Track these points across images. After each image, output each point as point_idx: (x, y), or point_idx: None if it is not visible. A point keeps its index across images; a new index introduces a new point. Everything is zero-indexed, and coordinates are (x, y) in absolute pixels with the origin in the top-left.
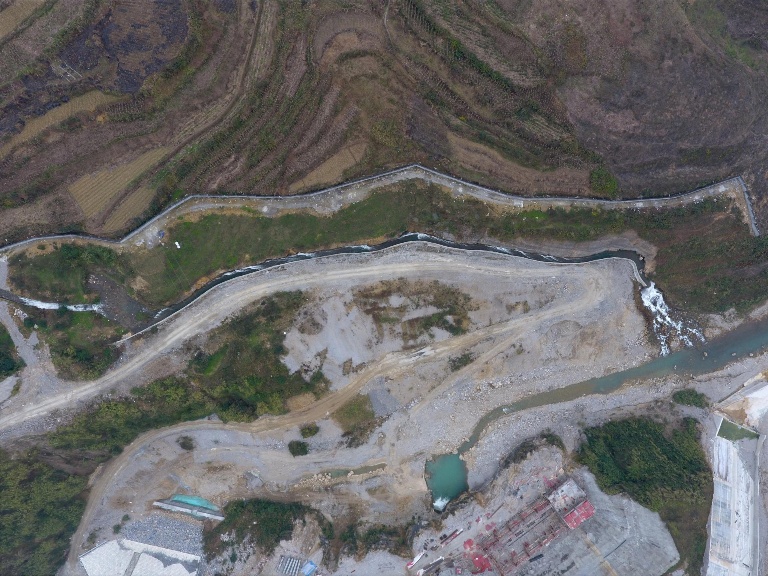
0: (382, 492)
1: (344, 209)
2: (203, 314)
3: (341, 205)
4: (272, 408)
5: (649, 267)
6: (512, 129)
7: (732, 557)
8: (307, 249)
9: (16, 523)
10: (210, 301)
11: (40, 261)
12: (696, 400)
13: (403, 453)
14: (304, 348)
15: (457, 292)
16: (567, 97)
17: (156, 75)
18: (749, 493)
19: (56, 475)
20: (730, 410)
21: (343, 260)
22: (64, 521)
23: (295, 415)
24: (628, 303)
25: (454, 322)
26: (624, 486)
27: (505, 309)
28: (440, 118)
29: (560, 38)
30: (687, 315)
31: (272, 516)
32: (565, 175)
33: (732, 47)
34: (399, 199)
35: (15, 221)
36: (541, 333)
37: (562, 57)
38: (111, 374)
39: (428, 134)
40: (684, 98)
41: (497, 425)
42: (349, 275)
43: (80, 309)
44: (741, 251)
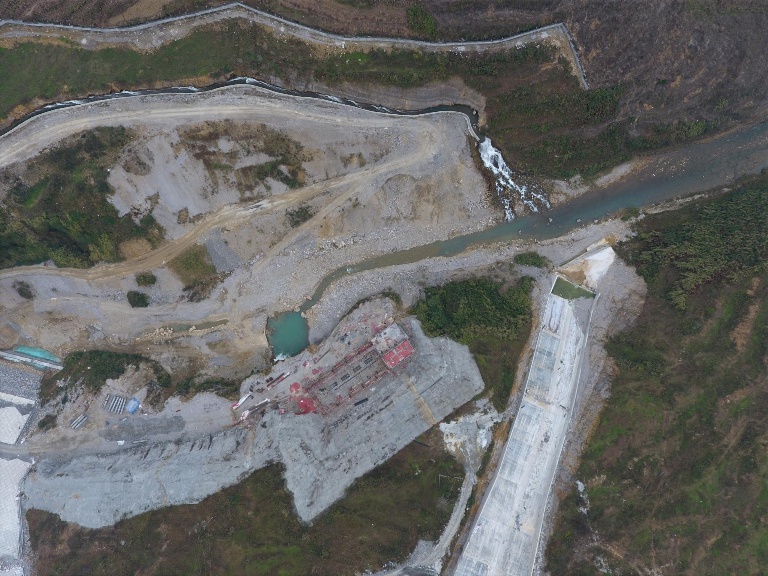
0: (222, 346)
1: (166, 45)
2: (21, 144)
3: (162, 41)
4: (103, 251)
5: (481, 120)
6: None
7: (549, 399)
8: (130, 86)
9: None
10: (29, 131)
11: None
12: (535, 260)
13: (244, 309)
14: (132, 189)
15: (287, 139)
16: None
17: None
18: (578, 345)
19: None
20: (569, 271)
21: (168, 99)
22: None
23: (131, 263)
24: (464, 159)
25: (289, 173)
26: (445, 328)
27: (340, 161)
28: None
29: None
30: (531, 180)
31: (105, 361)
32: (383, 13)
33: None
34: (222, 38)
35: None
36: (376, 186)
37: None
38: None
39: None
40: None
41: (339, 284)
42: (174, 114)
43: None
44: (574, 107)
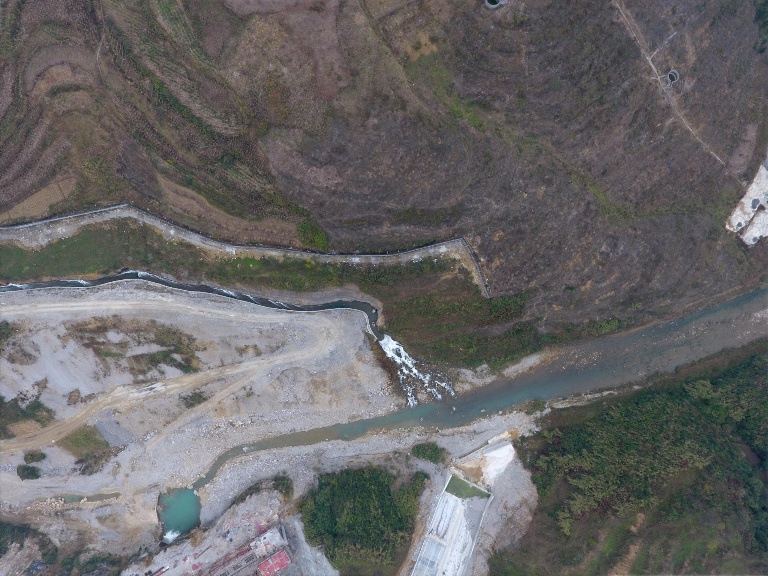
0: (112, 521)
1: (52, 244)
2: None
3: (49, 239)
4: None
5: (380, 320)
6: (215, 176)
7: None
8: (15, 281)
9: None
10: None
11: None
12: (432, 455)
13: (137, 484)
14: (18, 377)
15: (179, 332)
16: (269, 148)
17: None
18: (464, 553)
19: None
20: (467, 467)
21: (55, 294)
22: None
23: (21, 440)
24: (362, 354)
25: (183, 360)
26: (324, 539)
27: (235, 351)
28: (149, 159)
29: (262, 88)
30: (436, 368)
31: None
32: (273, 226)
33: (458, 106)
34: (112, 237)
35: None
36: (271, 378)
37: (263, 108)
38: None
39: (138, 174)
40: (388, 158)
41: (233, 464)
42: (60, 309)
43: None
44: (477, 311)
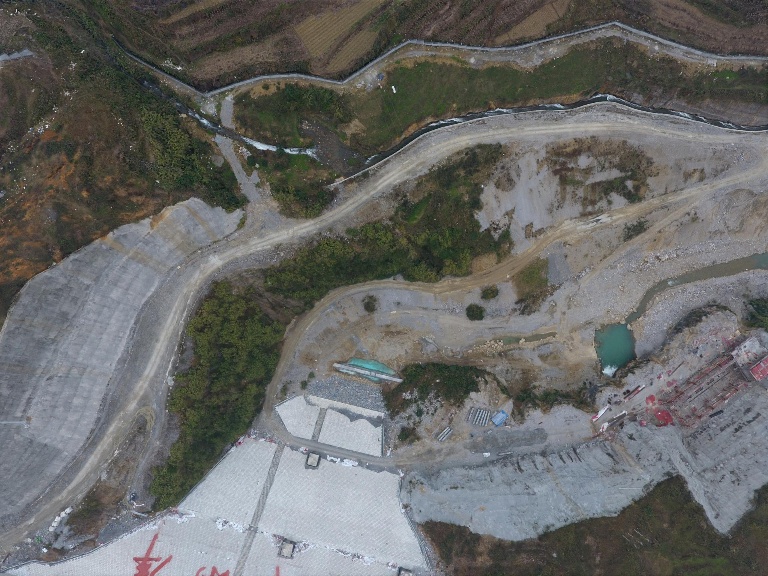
0: (553, 358)
1: (545, 64)
2: (411, 161)
3: (542, 60)
4: (461, 266)
5: None
6: None
7: None
8: (507, 104)
9: (232, 359)
10: (418, 149)
11: (262, 102)
12: None
13: (573, 321)
14: (496, 205)
15: (642, 155)
16: None
17: None
18: None
19: (264, 318)
20: None
21: (539, 117)
22: (265, 367)
23: (476, 277)
24: None
25: (633, 188)
26: None
27: (682, 177)
28: None
29: None
30: None
31: (455, 374)
32: (761, 32)
33: None
34: (596, 57)
35: (244, 59)
36: (716, 201)
37: None
38: (328, 214)
39: None
40: None
41: (664, 296)
42: (544, 132)
43: (295, 153)
44: None
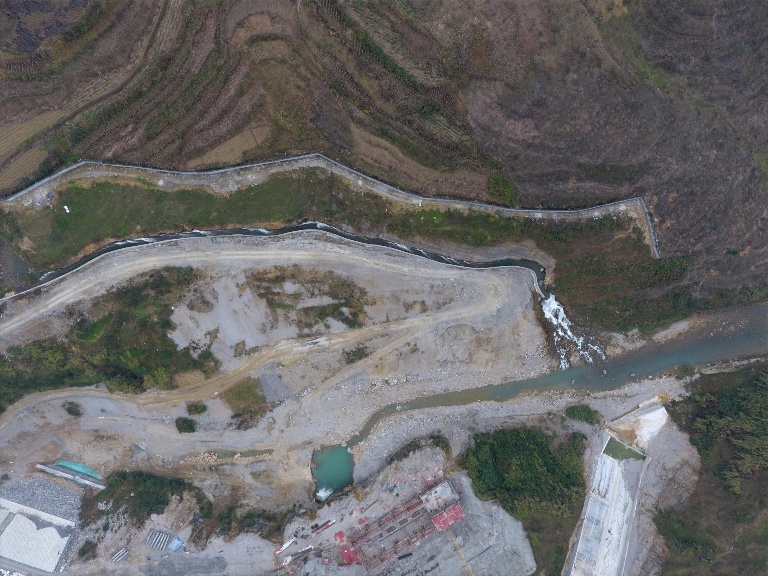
0: (266, 477)
1: (242, 190)
2: (89, 281)
3: (239, 186)
4: (158, 382)
5: (548, 279)
6: (413, 127)
7: (596, 574)
8: (202, 227)
9: None
10: (97, 268)
11: None
12: (587, 416)
13: (291, 440)
14: (193, 325)
15: (353, 285)
16: (469, 100)
17: (55, 37)
18: (626, 513)
19: None
20: (621, 429)
21: (238, 241)
22: None
23: (183, 392)
24: (526, 313)
25: (350, 315)
26: (497, 493)
27: (402, 307)
28: (344, 109)
29: (467, 40)
30: (589, 331)
31: (150, 489)
32: (464, 178)
33: (644, 67)
34: (299, 186)
35: None
36: (436, 334)
37: (467, 60)
38: None
39: (332, 124)
40: (586, 112)
41: (388, 422)
42: (243, 257)
43: None
44: (642, 272)
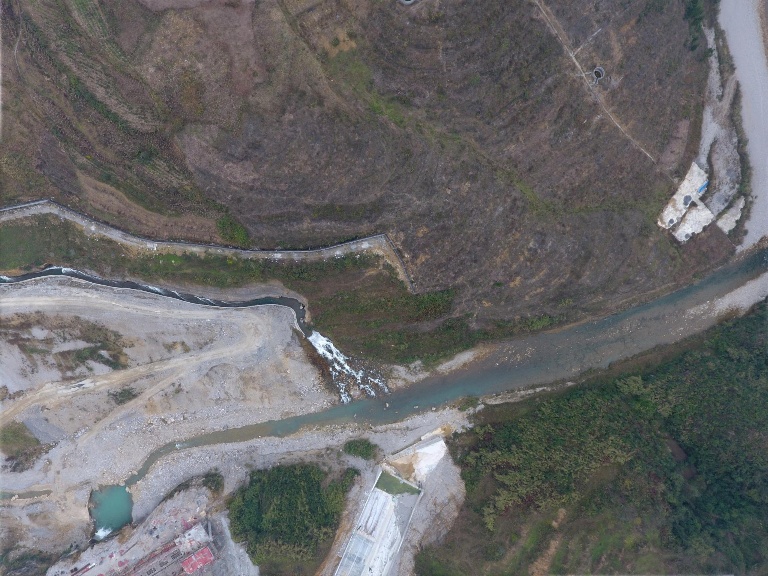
0: (43, 518)
1: None
2: None
3: None
4: None
5: (307, 317)
6: (133, 172)
7: None
8: None
9: None
10: None
11: None
12: (363, 451)
13: (68, 481)
14: None
15: (104, 328)
16: (186, 144)
17: None
18: (392, 549)
19: None
20: (398, 463)
21: None
22: None
23: None
24: (291, 350)
25: (110, 357)
26: (248, 535)
27: (163, 348)
28: (68, 155)
29: (177, 84)
30: (369, 365)
31: None
32: (193, 222)
33: (378, 102)
34: (33, 233)
35: None
36: (200, 374)
37: (179, 103)
38: None
39: (58, 170)
40: (305, 153)
41: (165, 460)
42: None
43: None
44: (404, 307)
